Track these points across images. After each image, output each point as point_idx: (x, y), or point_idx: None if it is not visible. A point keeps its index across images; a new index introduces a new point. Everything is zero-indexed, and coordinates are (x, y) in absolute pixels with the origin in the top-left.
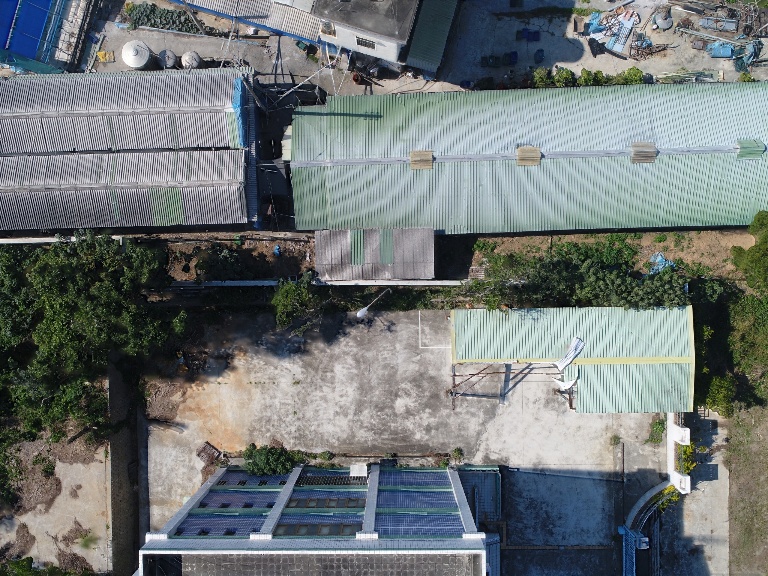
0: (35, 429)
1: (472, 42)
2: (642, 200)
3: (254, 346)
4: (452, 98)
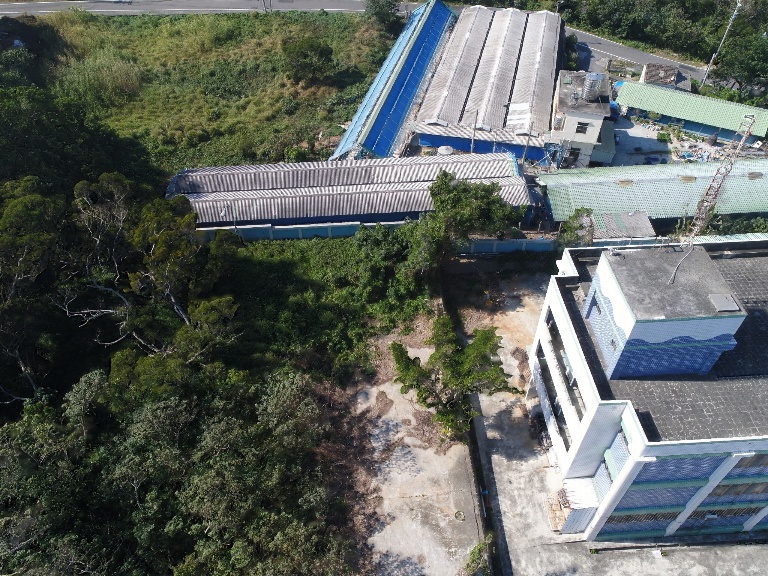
0: (392, 323)
1: (621, 162)
2: (766, 197)
3: (538, 290)
4: (627, 167)
